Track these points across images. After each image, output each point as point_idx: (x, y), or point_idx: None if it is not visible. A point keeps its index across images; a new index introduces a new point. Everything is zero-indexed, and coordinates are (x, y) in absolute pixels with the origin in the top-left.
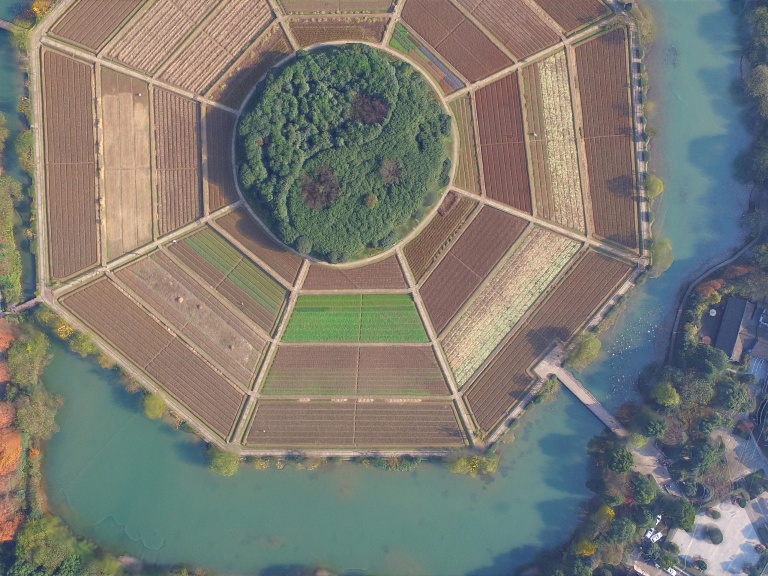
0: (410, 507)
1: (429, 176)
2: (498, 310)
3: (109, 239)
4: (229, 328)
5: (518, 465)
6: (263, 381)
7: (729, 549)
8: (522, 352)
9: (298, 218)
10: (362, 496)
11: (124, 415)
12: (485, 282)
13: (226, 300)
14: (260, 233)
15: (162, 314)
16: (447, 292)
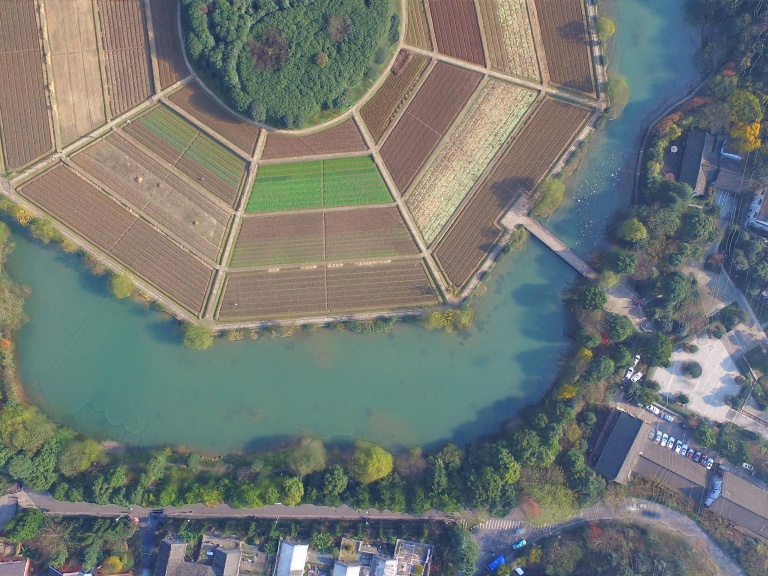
0: (389, 369)
1: (378, 30)
2: (460, 165)
3: (62, 124)
4: (191, 204)
5: (493, 318)
6: (230, 254)
7: (710, 383)
8: (488, 205)
9: (249, 83)
10: (340, 362)
11: (93, 300)
12: (445, 138)
13: (186, 176)
14: (214, 106)
15: (122, 195)
16: (407, 151)
